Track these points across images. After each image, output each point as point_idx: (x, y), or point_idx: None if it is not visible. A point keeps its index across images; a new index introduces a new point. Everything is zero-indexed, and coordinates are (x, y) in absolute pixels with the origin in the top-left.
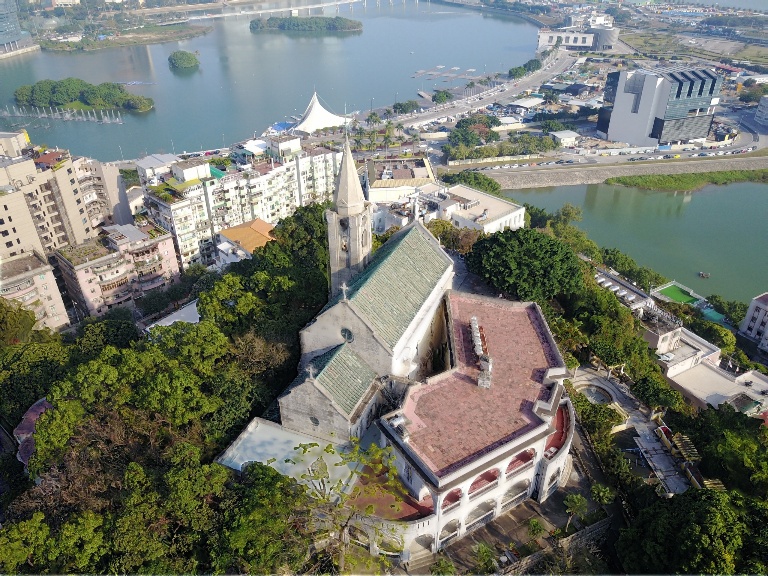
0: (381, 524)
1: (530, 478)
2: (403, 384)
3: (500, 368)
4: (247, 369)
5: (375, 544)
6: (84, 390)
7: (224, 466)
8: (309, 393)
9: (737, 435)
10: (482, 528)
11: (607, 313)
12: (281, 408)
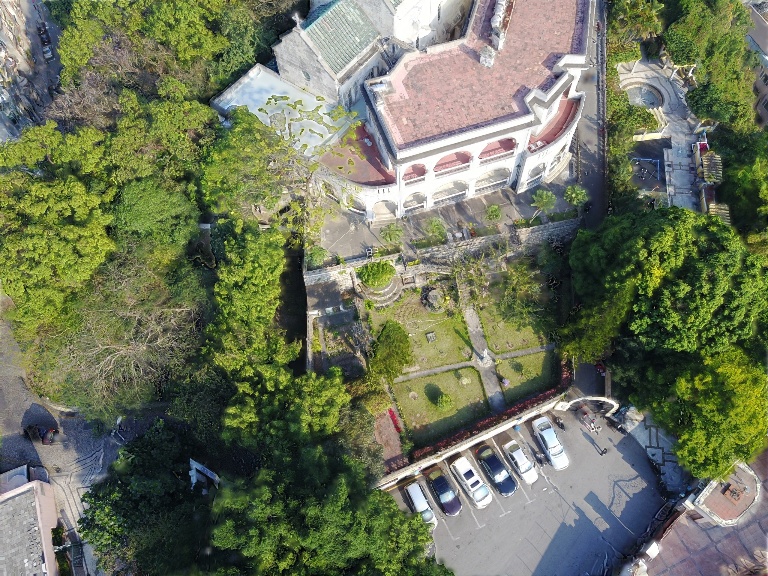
0: (345, 183)
1: (510, 168)
2: (407, 50)
3: (514, 46)
4: (257, 10)
5: (344, 200)
6: (99, 11)
7: (218, 107)
8: (297, 44)
9: None
10: (451, 205)
11: None
12: (277, 57)
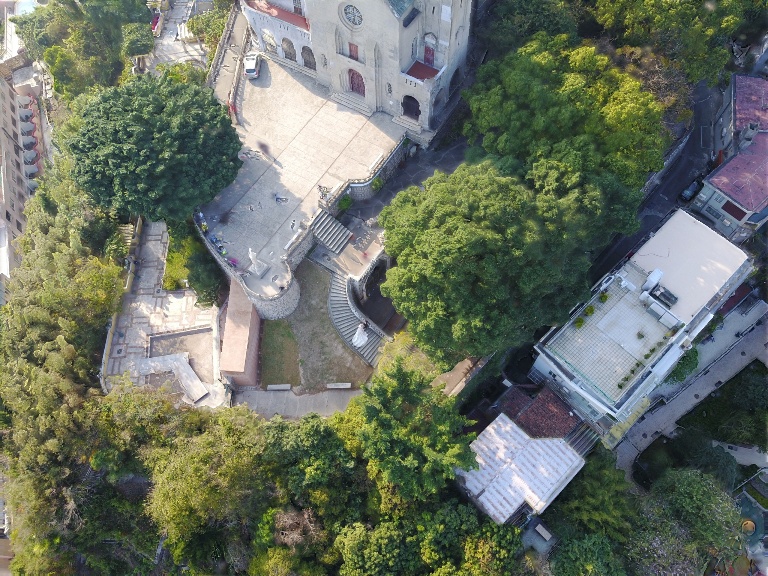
0: None
1: None
2: None
3: None
4: None
5: None
6: None
7: None
8: None
9: None
10: None
11: None
12: None
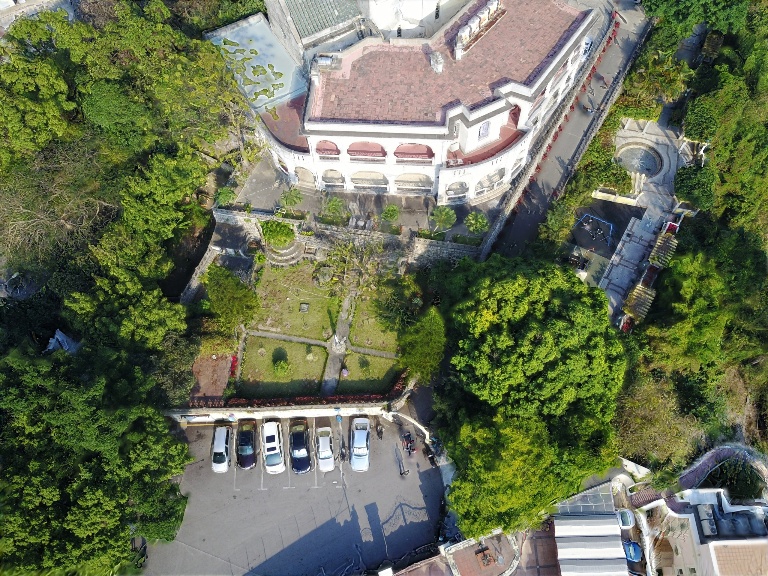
0: (270, 140)
1: (431, 177)
2: (384, 36)
3: (473, 60)
4: None
5: (275, 157)
6: None
7: None
8: (275, 1)
9: (734, 271)
10: (372, 195)
11: (746, 76)
12: (267, 9)
